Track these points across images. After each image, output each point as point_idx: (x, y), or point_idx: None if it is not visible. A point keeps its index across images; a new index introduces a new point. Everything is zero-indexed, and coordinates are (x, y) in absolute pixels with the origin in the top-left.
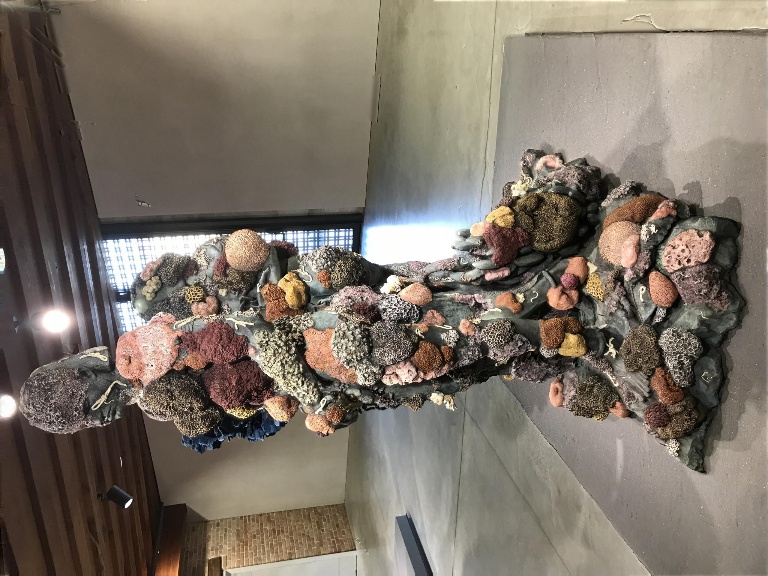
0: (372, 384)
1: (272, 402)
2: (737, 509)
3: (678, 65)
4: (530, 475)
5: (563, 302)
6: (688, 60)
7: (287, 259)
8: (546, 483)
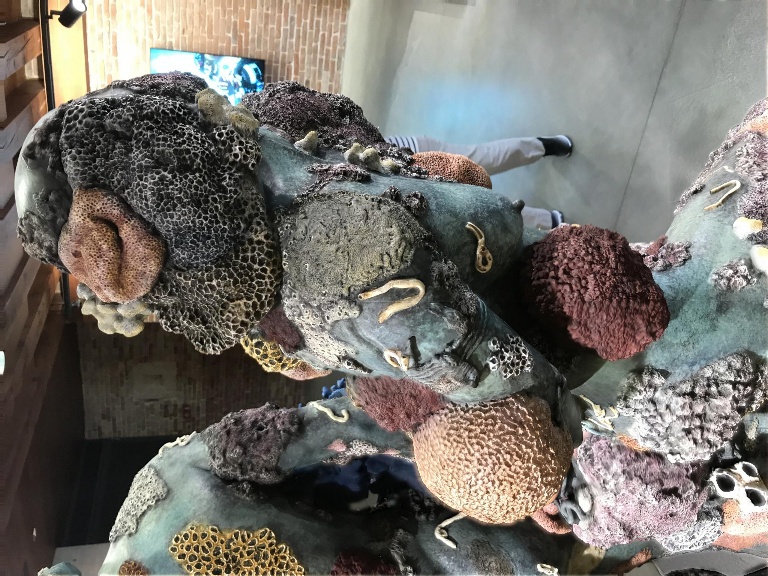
0: None
1: None
2: (754, 568)
3: None
4: (717, 17)
5: None
6: None
7: (600, 365)
8: (717, 73)
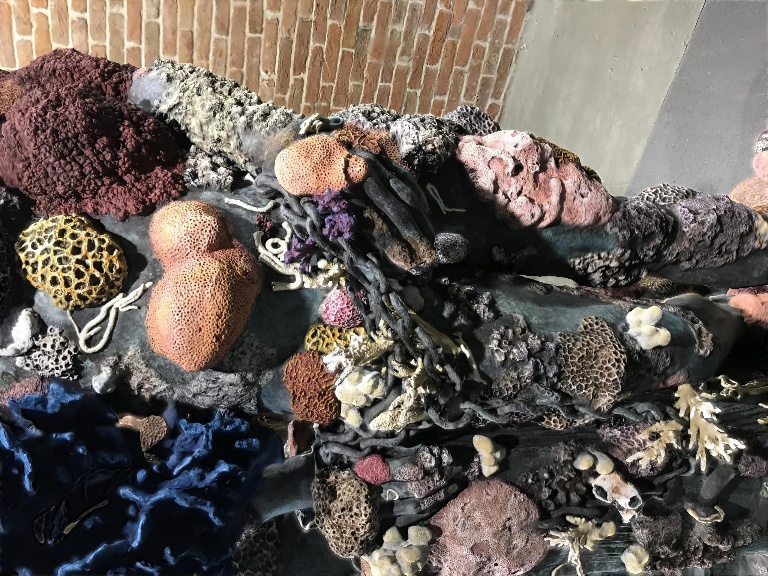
0: (438, 141)
1: (175, 206)
2: None
3: (661, 162)
4: None
5: (767, 297)
6: (664, 145)
7: None
8: None
